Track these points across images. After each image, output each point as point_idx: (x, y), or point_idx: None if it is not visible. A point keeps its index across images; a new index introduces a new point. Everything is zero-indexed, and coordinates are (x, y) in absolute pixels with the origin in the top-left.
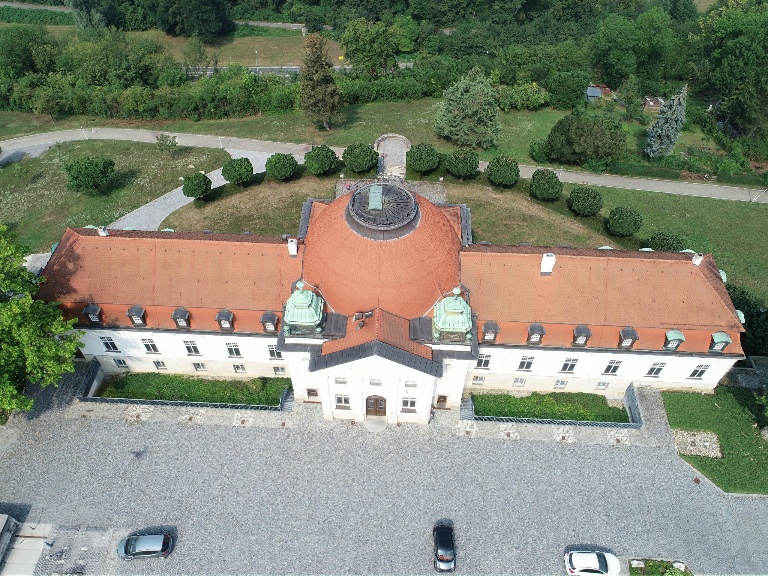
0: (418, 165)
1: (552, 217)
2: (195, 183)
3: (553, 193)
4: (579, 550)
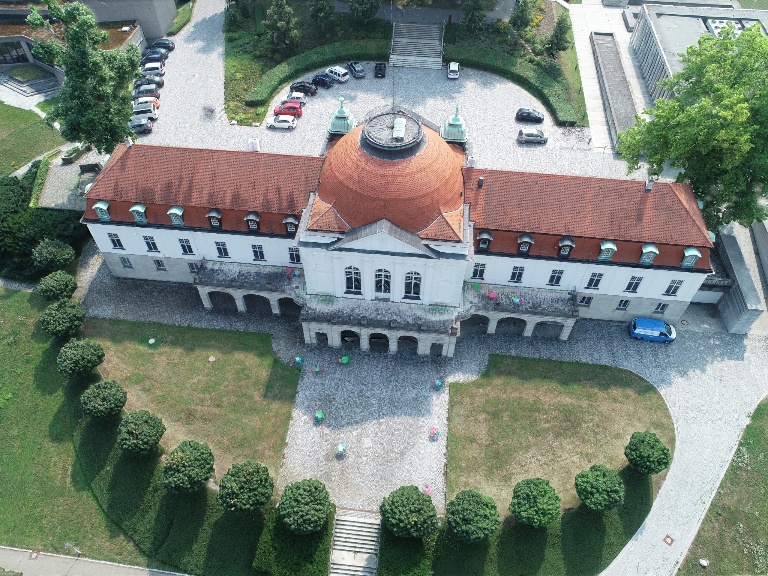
0: (318, 480)
1: None
2: (647, 439)
3: (142, 410)
4: (285, 131)
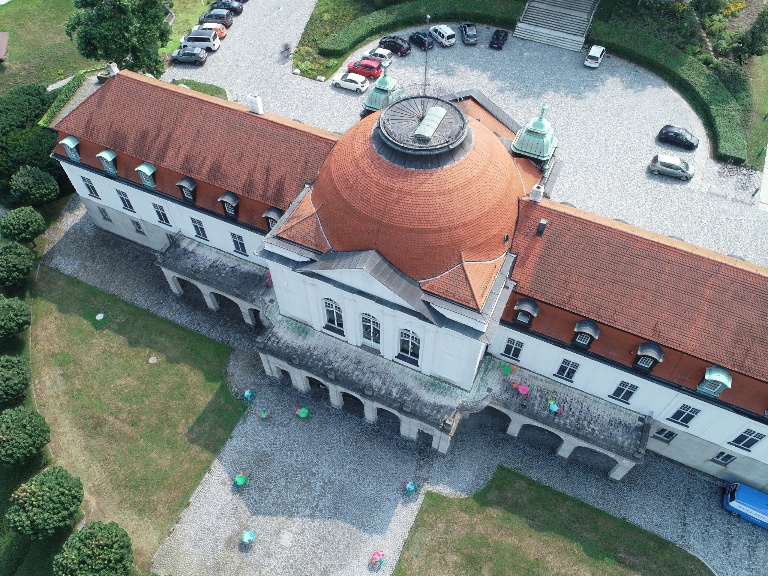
0: None
1: (56, 414)
2: None
3: (31, 408)
4: (352, 93)
